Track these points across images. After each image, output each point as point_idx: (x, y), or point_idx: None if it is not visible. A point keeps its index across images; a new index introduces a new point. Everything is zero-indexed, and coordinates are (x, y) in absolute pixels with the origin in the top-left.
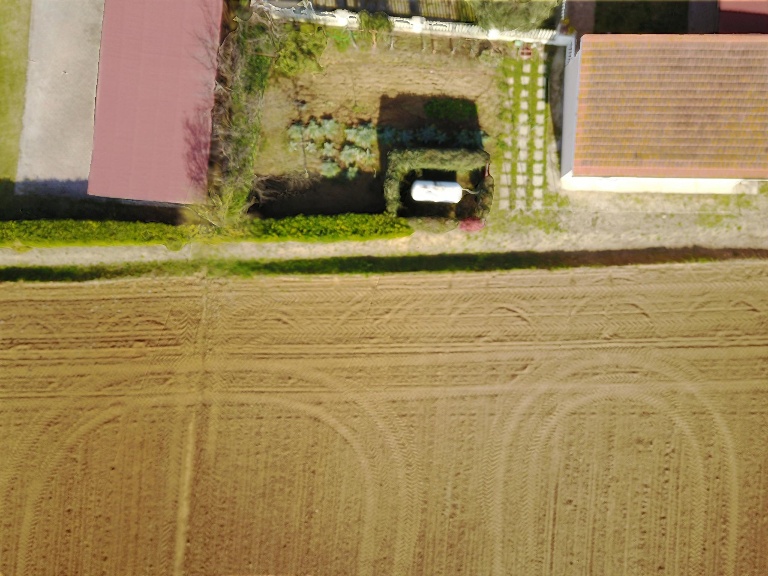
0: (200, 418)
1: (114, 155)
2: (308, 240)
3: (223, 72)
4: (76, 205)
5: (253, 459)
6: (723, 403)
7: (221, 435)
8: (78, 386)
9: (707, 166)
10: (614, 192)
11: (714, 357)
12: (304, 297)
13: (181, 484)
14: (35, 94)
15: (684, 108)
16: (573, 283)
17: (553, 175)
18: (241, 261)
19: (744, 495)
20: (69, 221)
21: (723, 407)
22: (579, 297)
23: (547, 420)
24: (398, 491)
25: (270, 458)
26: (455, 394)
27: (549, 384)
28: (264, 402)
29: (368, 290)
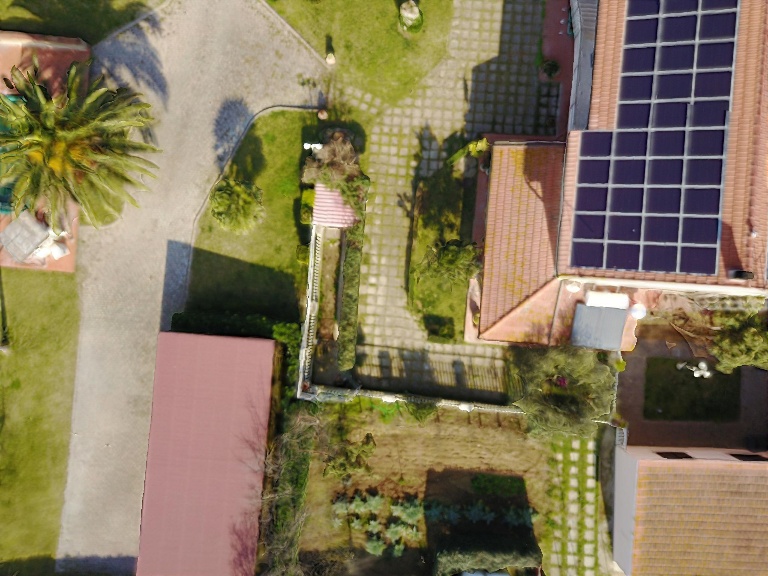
0: None
1: (160, 565)
2: None
3: (270, 473)
4: None
5: None
6: None
7: None
8: None
9: None
10: None
11: None
12: None
13: None
14: (78, 468)
15: (745, 532)
16: None
17: (605, 556)
18: None
19: None
20: None
21: None
22: None
23: None
24: None
25: None
26: None
27: None
28: None
29: None
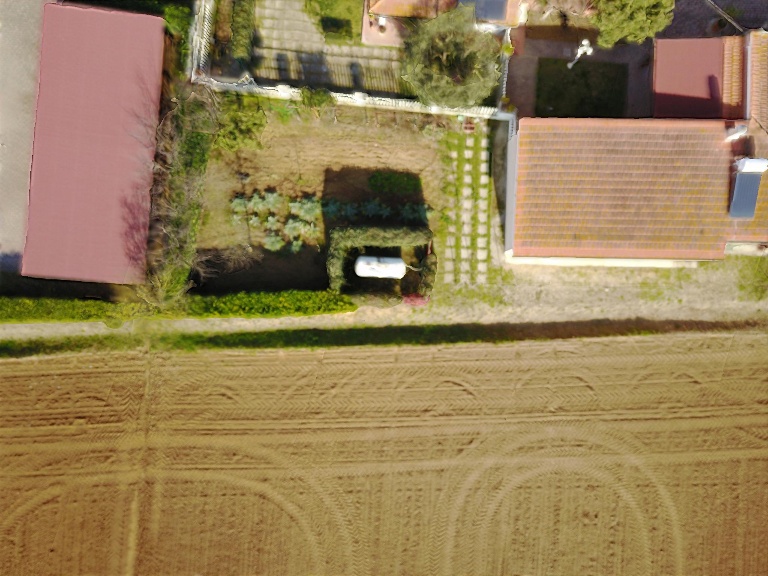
0: (143, 496)
1: (50, 236)
2: (251, 317)
3: (162, 150)
4: (14, 280)
5: (197, 538)
6: (666, 475)
7: (164, 514)
8: (16, 466)
9: (644, 247)
10: (557, 266)
11: (657, 429)
12: (249, 371)
13: (123, 565)
14: None
15: (621, 190)
16: (518, 356)
17: (497, 249)
18: (185, 335)
19: (687, 567)
20: (5, 300)
21: (666, 479)
22: (524, 370)
23: (493, 494)
24: (344, 568)
25: (214, 537)
26: (401, 469)
27: (495, 458)
28: (208, 479)
29: (313, 364)
